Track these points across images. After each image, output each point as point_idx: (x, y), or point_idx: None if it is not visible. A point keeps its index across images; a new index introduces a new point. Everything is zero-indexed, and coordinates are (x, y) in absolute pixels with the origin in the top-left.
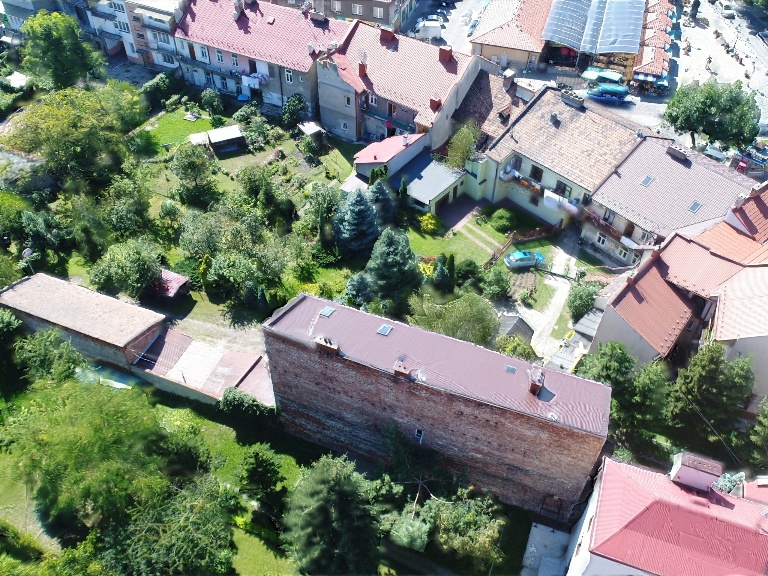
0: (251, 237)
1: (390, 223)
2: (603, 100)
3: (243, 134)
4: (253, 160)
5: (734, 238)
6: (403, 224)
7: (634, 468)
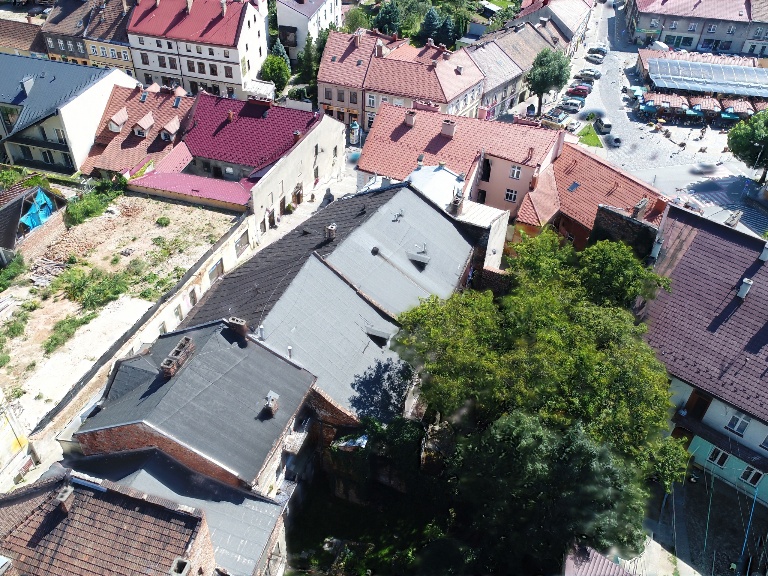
0: (409, 8)
1: (445, 43)
2: (619, 101)
3: (497, 11)
4: (484, 20)
5: (415, 54)
6: (448, 47)
7: None
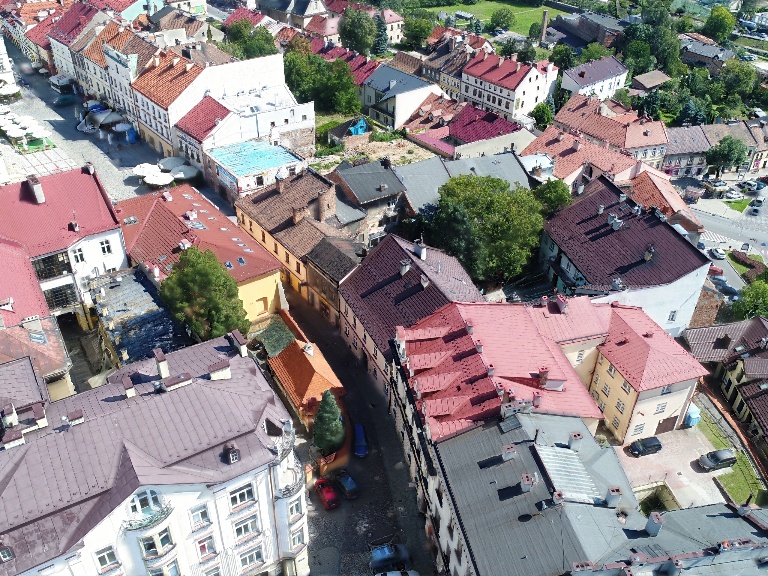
0: None
1: None
2: None
3: None
4: None
5: None
6: None
7: (555, 68)
